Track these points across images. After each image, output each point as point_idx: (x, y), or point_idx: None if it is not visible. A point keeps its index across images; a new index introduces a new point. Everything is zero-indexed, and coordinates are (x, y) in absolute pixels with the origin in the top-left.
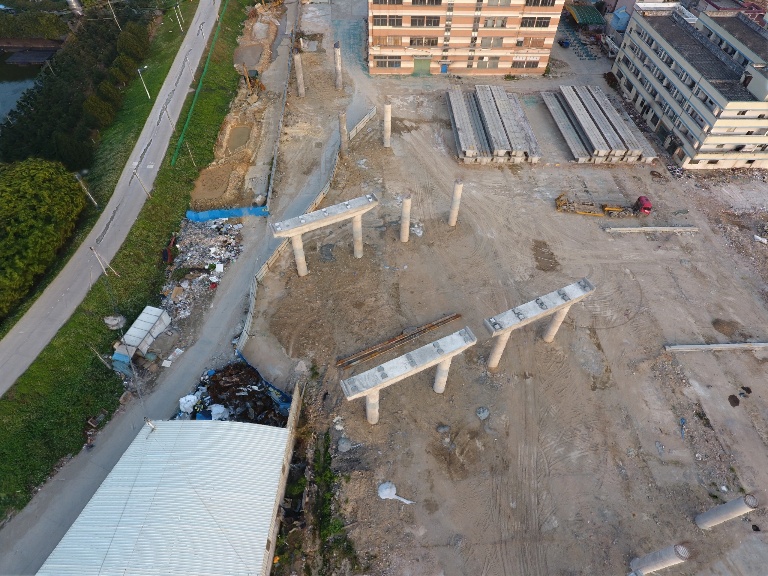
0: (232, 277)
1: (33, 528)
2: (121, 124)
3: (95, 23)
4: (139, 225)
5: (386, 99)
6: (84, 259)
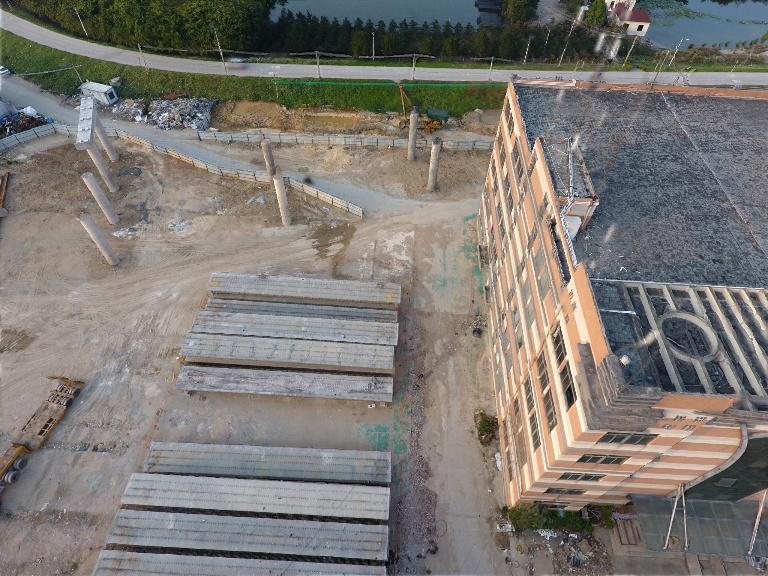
0: (137, 127)
1: (10, 83)
2: (354, 61)
3: (551, 30)
4: (196, 75)
5: (401, 230)
6: (172, 62)
